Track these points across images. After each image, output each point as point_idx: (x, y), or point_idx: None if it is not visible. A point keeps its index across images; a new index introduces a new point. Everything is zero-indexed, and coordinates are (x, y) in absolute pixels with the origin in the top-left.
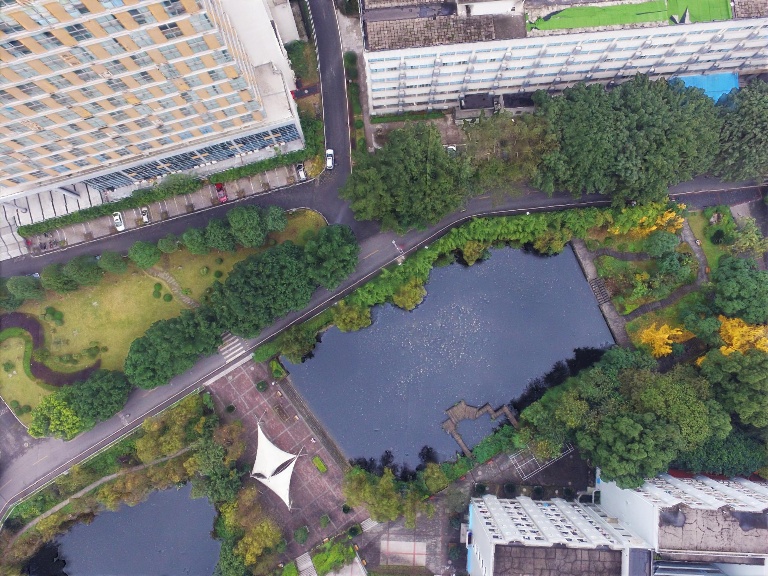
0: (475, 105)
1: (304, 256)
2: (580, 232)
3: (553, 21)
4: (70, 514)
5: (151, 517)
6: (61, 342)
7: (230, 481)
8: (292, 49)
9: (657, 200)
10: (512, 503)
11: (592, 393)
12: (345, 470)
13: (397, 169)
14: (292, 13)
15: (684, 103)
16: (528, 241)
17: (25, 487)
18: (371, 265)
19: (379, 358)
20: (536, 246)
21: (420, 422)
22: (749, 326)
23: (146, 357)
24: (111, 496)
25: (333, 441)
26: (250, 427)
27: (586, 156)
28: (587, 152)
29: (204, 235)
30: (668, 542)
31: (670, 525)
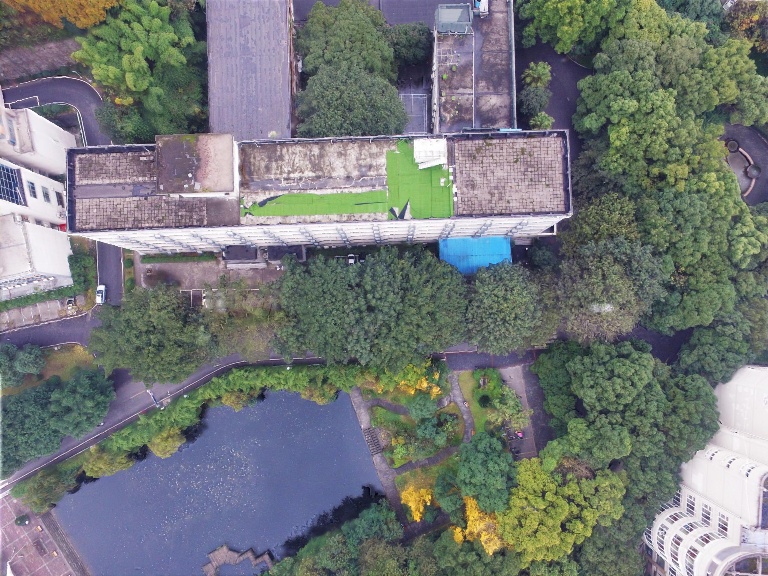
0: (237, 256)
1: (50, 405)
2: (343, 389)
3: (268, 207)
4: None
5: None
6: None
7: None
8: None
9: None
10: None
11: (326, 564)
12: None
13: None
14: (68, 144)
15: (428, 281)
16: None
17: None
18: (137, 405)
19: (145, 496)
20: (302, 397)
21: (181, 564)
22: None
23: None
24: None
25: None
26: None
27: (315, 336)
28: (315, 332)
29: None
30: None
31: None
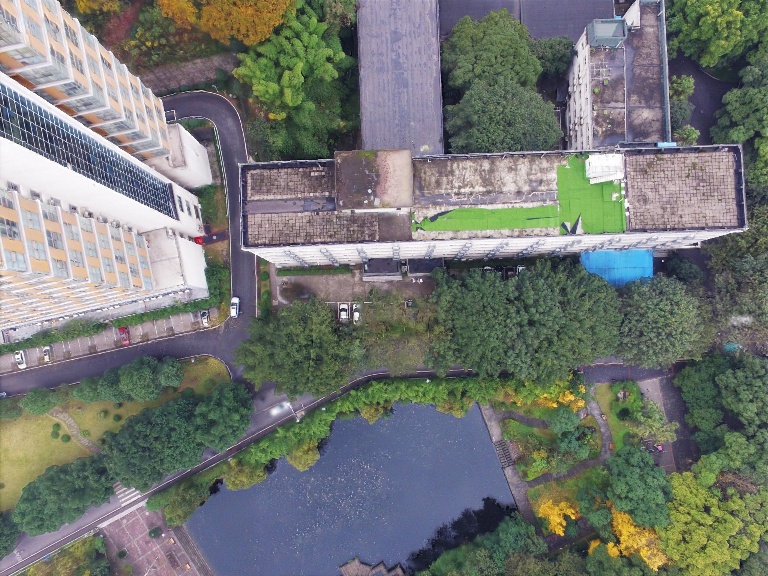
0: (379, 269)
1: (195, 418)
2: (481, 402)
3: (440, 222)
4: None
5: None
6: None
7: None
8: (203, 193)
9: (559, 379)
10: None
11: None
12: None
13: (280, 354)
14: (204, 157)
15: (583, 295)
16: (431, 403)
17: None
18: (270, 418)
19: (276, 509)
20: (438, 410)
21: None
22: (638, 525)
23: (35, 506)
24: None
25: None
26: (141, 572)
27: (475, 350)
28: (476, 346)
29: (96, 389)
30: None
31: None
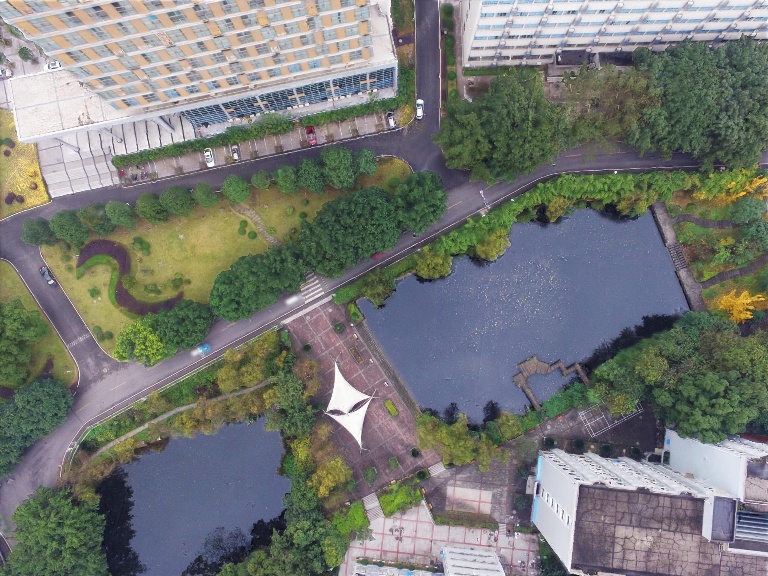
0: (571, 61)
1: (394, 199)
2: (666, 194)
3: None
4: (143, 441)
5: (220, 450)
6: (148, 271)
7: (306, 416)
8: None
9: (748, 166)
10: (581, 457)
11: (673, 351)
12: (415, 415)
13: (500, 114)
14: None
15: None
16: (611, 202)
17: (102, 411)
18: (454, 216)
19: (454, 309)
20: (619, 207)
21: (491, 374)
22: None
23: (232, 289)
24: (189, 423)
25: (405, 387)
26: (325, 367)
27: (688, 112)
28: (689, 108)
29: (297, 173)
30: (753, 493)
31: (756, 477)
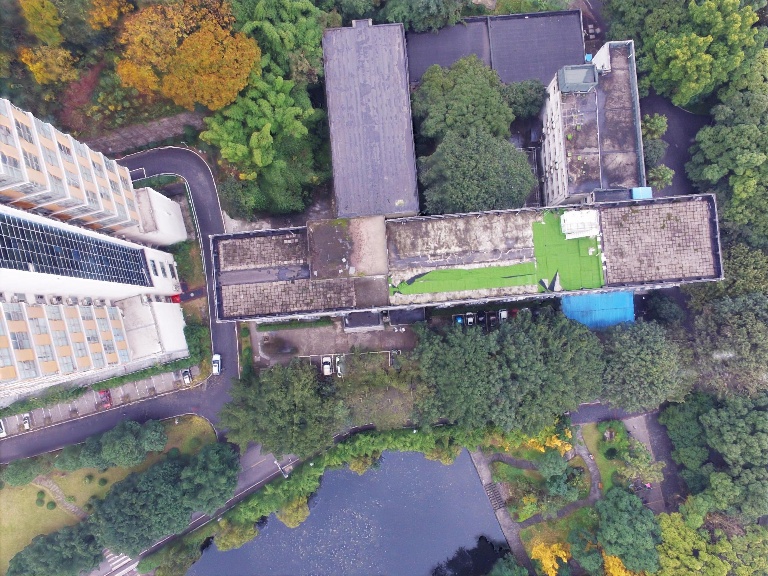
0: (360, 322)
1: (181, 483)
2: (469, 449)
3: (417, 285)
4: None
5: None
6: None
7: None
8: (177, 250)
9: None
10: None
11: None
12: None
13: None
14: (176, 214)
15: (565, 344)
16: None
17: None
18: (258, 474)
19: (269, 564)
20: None
21: None
22: None
23: None
24: None
25: None
26: None
27: (459, 406)
28: (460, 403)
29: (79, 459)
30: None
31: None
